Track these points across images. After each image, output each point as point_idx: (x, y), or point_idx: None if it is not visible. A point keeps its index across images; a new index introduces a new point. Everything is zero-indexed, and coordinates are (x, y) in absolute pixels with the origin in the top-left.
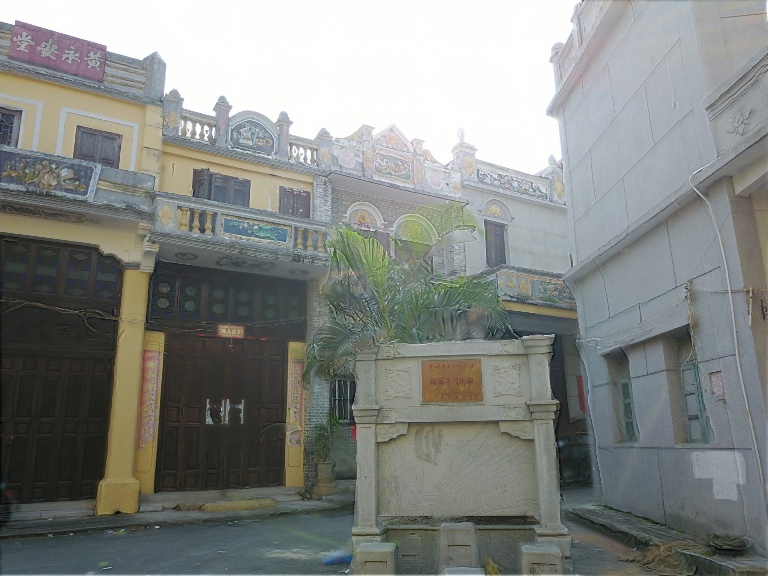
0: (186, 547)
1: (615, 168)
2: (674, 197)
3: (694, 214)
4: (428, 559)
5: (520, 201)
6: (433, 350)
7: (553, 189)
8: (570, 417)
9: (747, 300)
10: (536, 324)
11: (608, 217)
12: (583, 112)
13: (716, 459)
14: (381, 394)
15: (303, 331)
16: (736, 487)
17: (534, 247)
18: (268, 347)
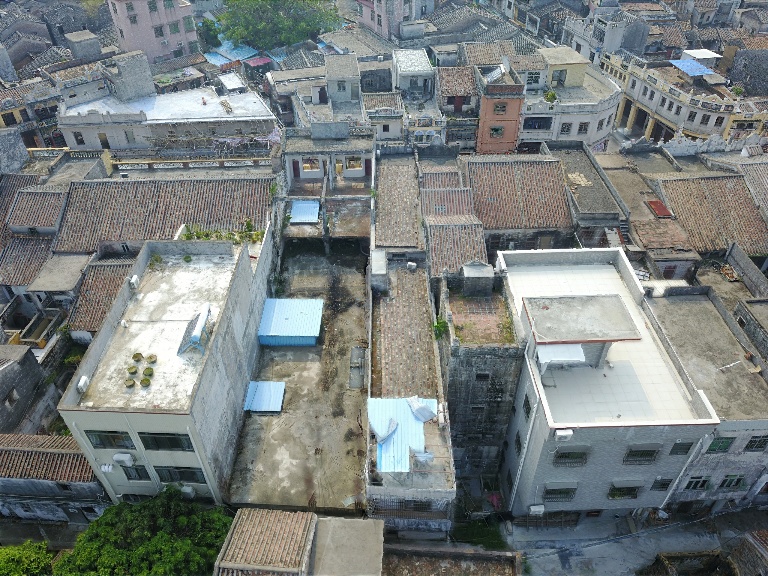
0: None
1: None
2: None
3: None
4: None
5: None
6: None
7: None
8: None
9: None
10: None
11: None
12: None
13: None
14: None
15: (35, 134)
16: None
17: None
18: None
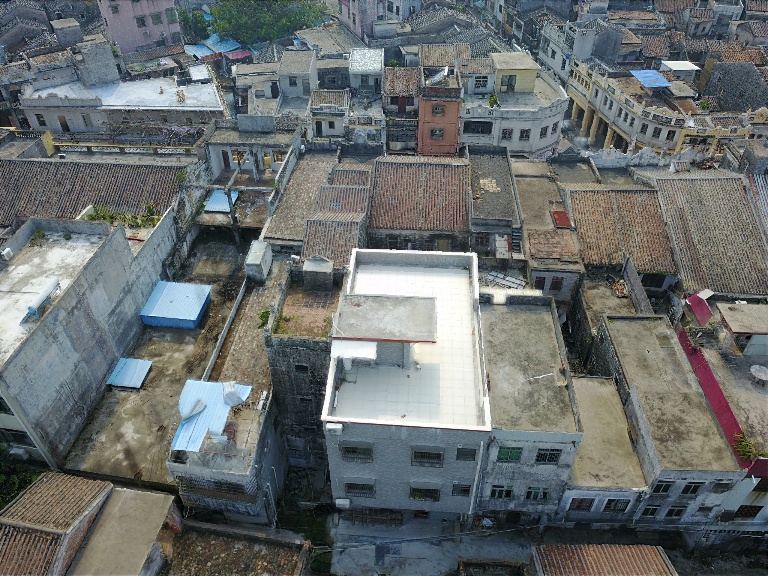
0: None
1: None
2: None
3: None
4: None
5: None
6: None
7: None
8: None
9: None
10: None
11: None
12: None
13: None
14: None
15: (10, 114)
16: None
17: None
18: (5, 118)
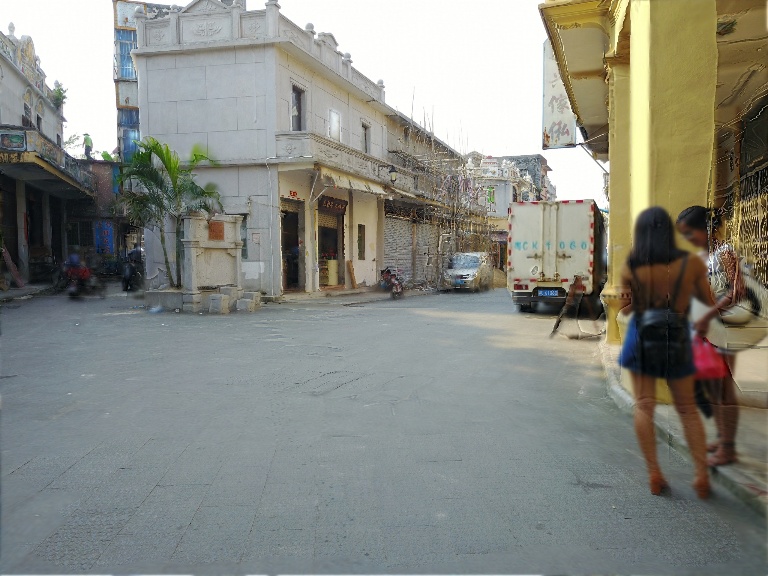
0: (48, 319)
1: (201, 124)
2: (254, 162)
3: (259, 171)
4: (203, 303)
5: (7, 63)
6: (212, 217)
7: (17, 56)
8: (18, 243)
9: (279, 211)
10: (16, 171)
11: (189, 146)
12: (173, 76)
13: (249, 265)
14: (196, 235)
15: None
16: (259, 274)
17: (10, 105)
18: None
